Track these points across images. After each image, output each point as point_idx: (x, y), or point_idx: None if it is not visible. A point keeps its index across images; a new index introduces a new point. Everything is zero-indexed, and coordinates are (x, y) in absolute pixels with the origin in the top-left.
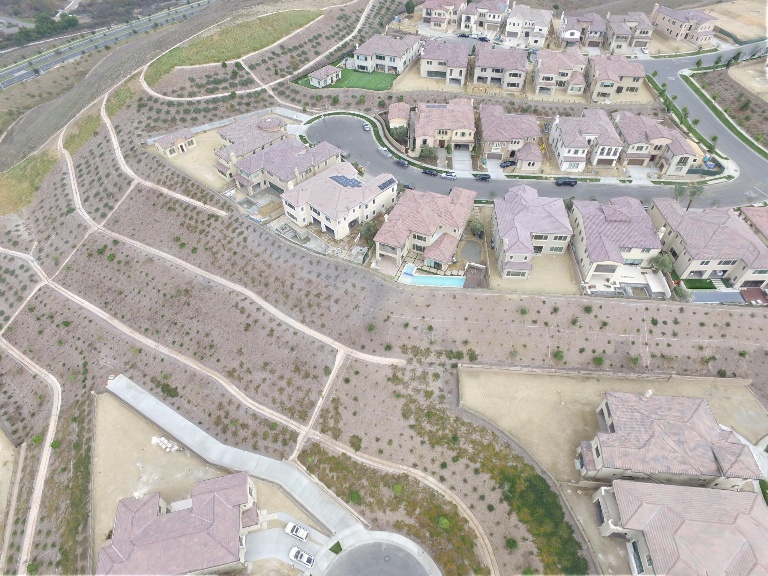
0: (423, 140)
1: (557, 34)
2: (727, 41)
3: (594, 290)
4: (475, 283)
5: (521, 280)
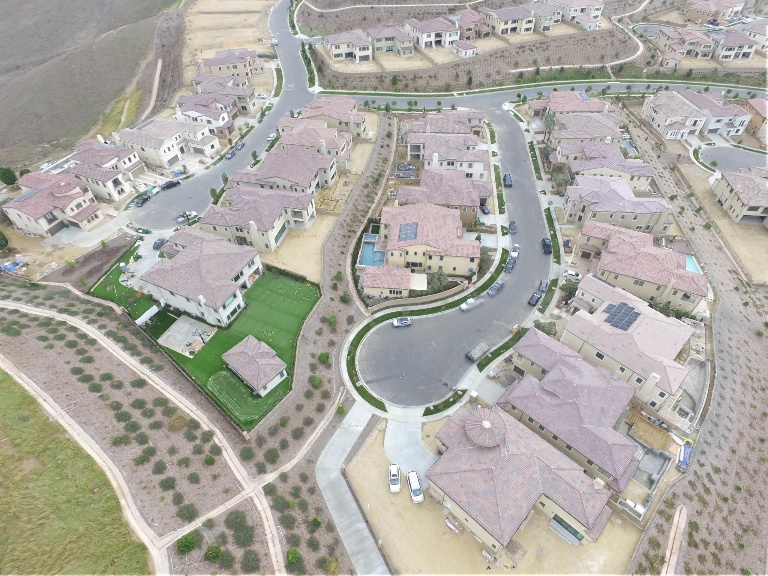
0: None
1: None
2: (266, 61)
3: None
4: (685, 248)
5: None
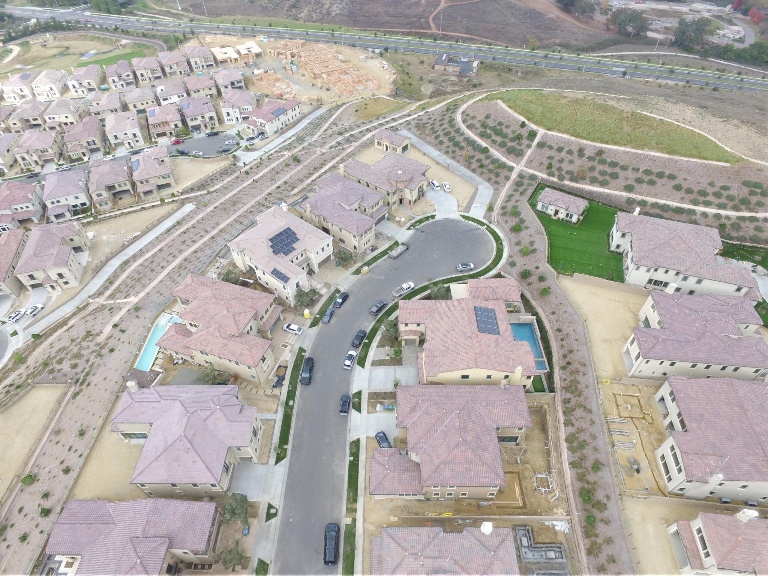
0: None
1: None
2: None
3: None
4: None
5: None
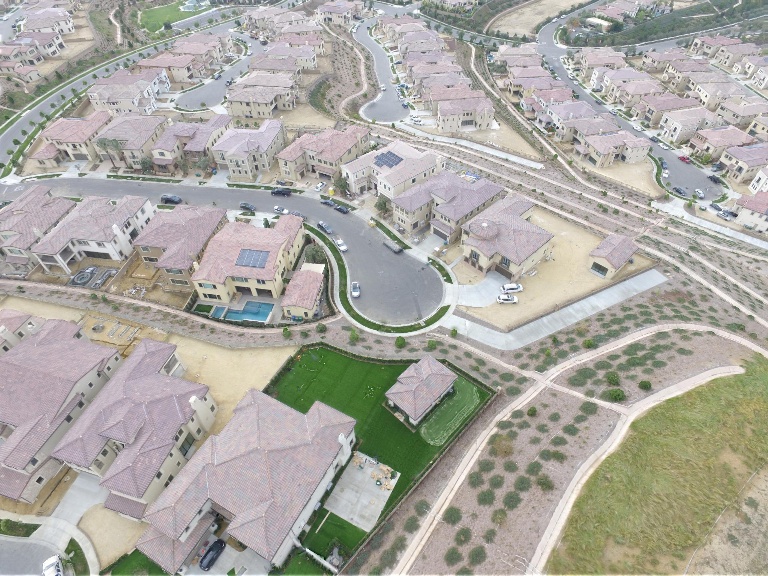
0: None
1: None
2: None
3: None
4: None
5: None
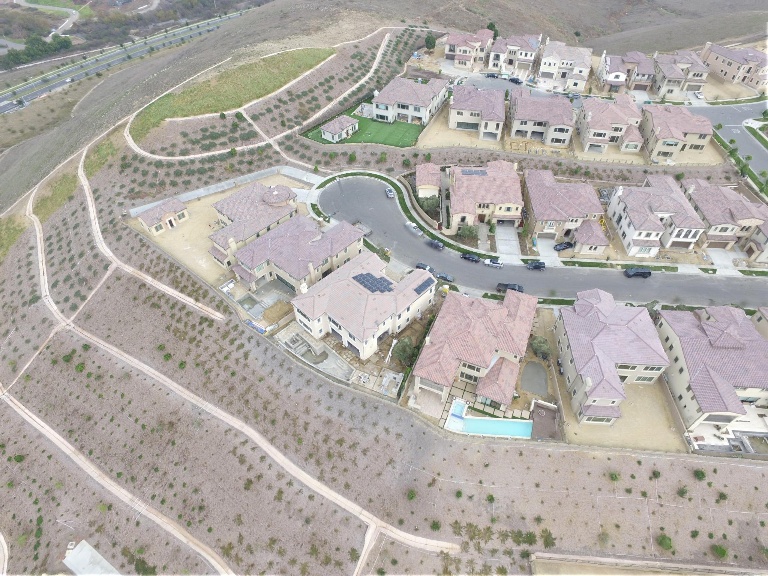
0: (461, 217)
1: (597, 74)
2: None
3: (702, 443)
4: (546, 432)
5: (605, 426)
